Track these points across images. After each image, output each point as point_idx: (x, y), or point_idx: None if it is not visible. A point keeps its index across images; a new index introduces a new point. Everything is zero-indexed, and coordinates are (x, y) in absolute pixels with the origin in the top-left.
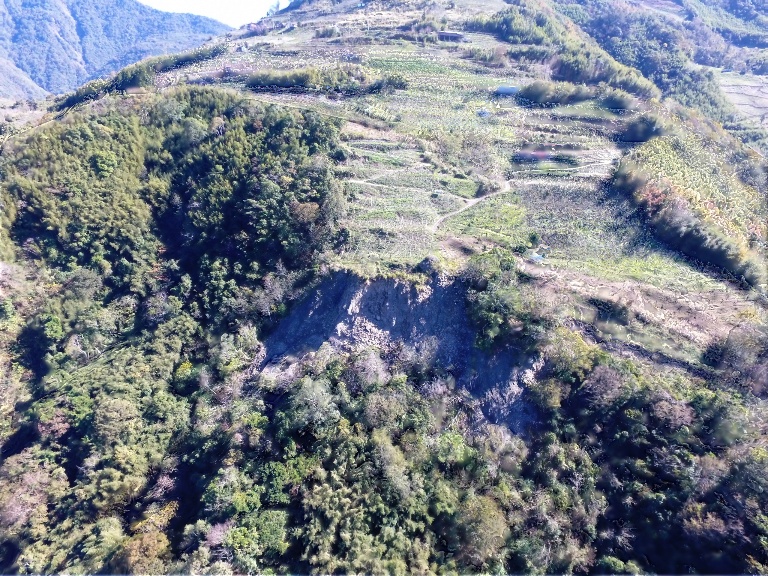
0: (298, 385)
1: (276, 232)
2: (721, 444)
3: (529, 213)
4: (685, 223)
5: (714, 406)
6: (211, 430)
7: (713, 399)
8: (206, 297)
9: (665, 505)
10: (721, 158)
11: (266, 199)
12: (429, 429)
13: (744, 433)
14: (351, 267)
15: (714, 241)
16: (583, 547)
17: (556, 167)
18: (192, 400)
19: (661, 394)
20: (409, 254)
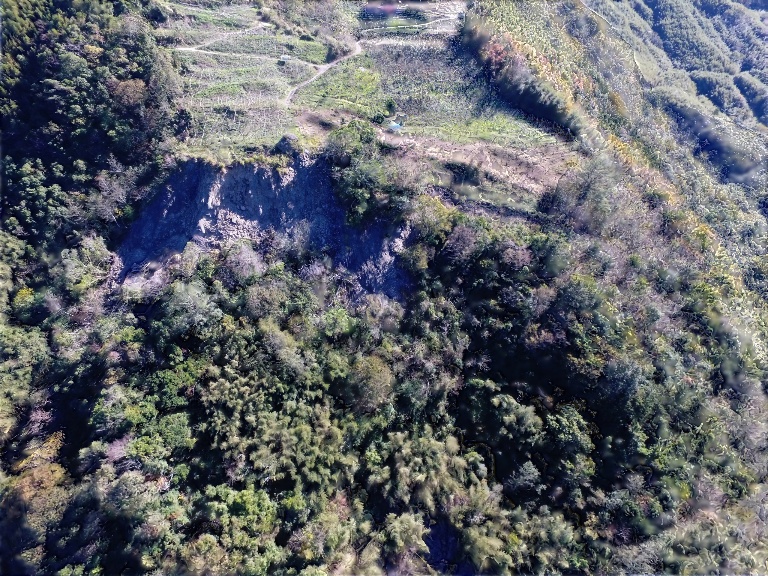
0: (169, 291)
1: (97, 120)
2: (551, 276)
3: (383, 78)
4: (524, 80)
5: (547, 246)
6: (79, 354)
7: (546, 241)
8: (26, 209)
9: (512, 331)
10: (553, 9)
11: (72, 78)
12: (313, 309)
13: (567, 264)
14: (201, 155)
15: (547, 97)
16: (454, 377)
17: (405, 23)
18: (45, 328)
19: (507, 243)
20: (264, 134)
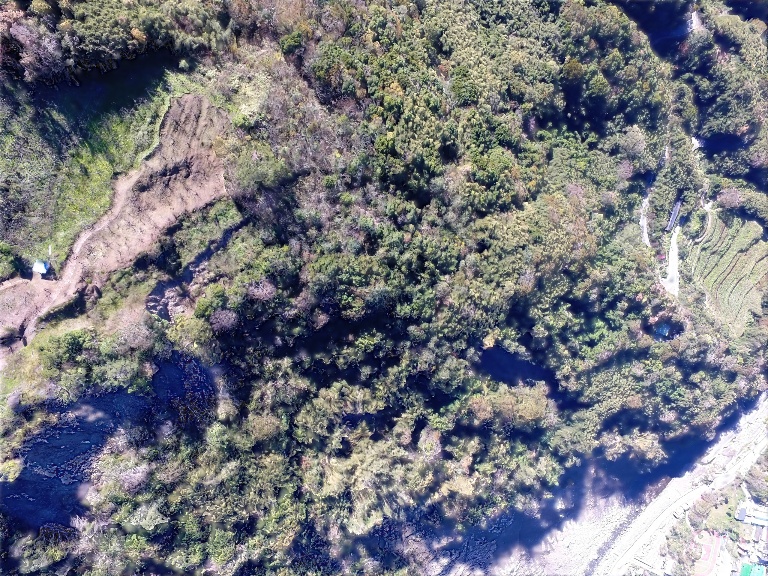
0: None
1: None
2: (296, 290)
3: None
4: None
5: None
6: (125, 561)
7: None
8: None
9: None
10: None
11: None
12: (204, 448)
13: (298, 273)
14: None
15: (106, 61)
16: None
17: None
18: (81, 570)
19: (252, 298)
20: (7, 428)
